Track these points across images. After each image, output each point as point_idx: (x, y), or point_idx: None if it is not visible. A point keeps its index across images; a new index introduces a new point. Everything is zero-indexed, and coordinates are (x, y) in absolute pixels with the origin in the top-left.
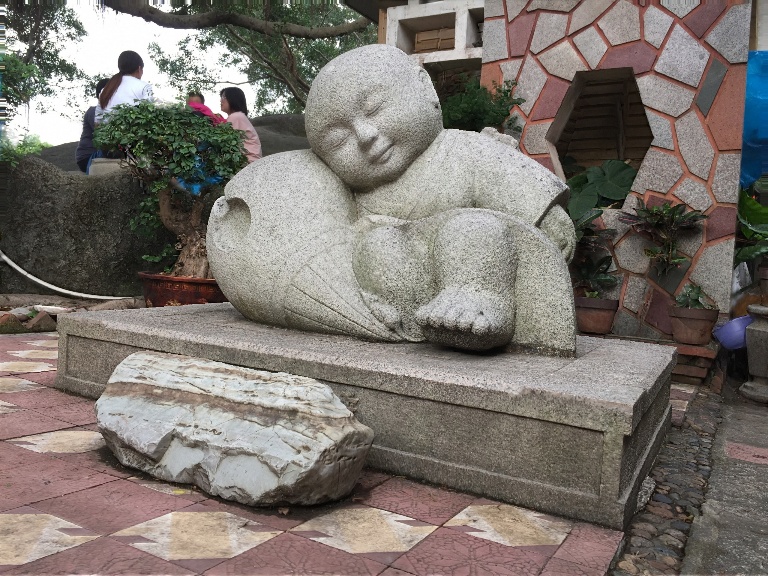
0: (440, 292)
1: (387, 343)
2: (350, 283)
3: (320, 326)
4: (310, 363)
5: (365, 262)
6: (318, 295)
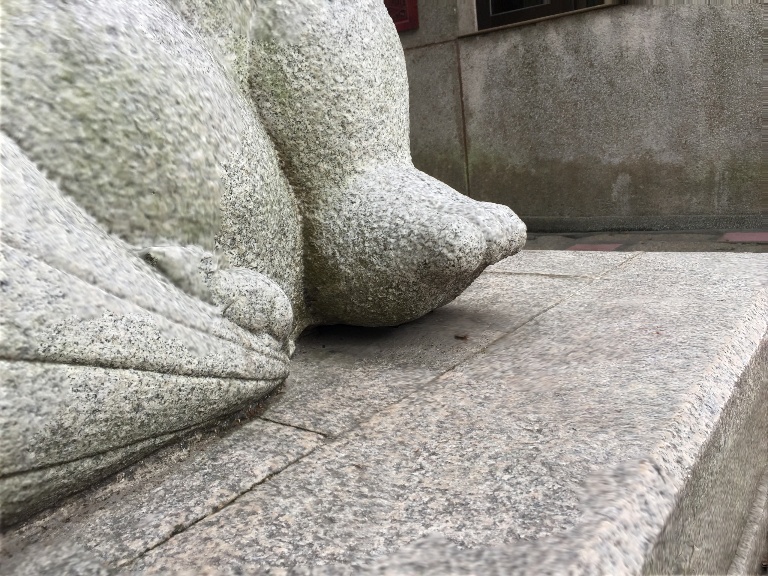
0: (348, 185)
1: (276, 393)
2: (82, 223)
3: (47, 484)
4: (645, 573)
5: (125, 114)
6: (17, 324)
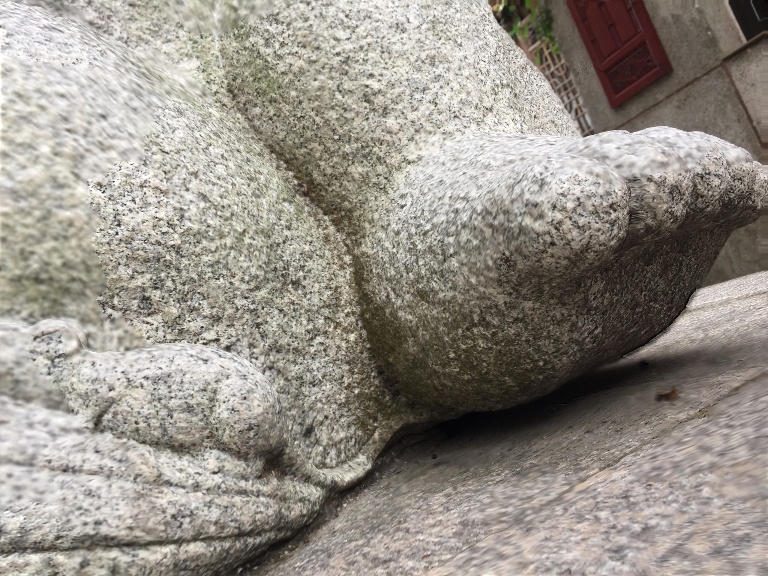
0: (396, 184)
1: (273, 560)
2: None
3: None
4: None
5: None
6: None
